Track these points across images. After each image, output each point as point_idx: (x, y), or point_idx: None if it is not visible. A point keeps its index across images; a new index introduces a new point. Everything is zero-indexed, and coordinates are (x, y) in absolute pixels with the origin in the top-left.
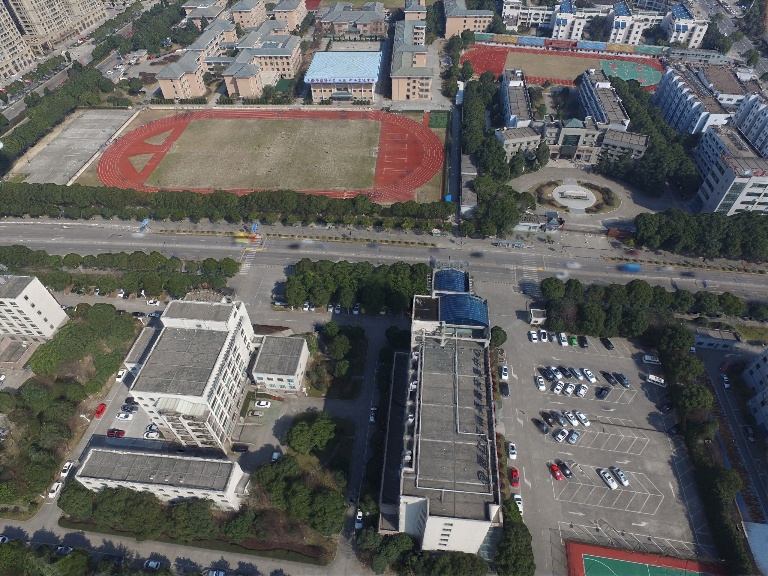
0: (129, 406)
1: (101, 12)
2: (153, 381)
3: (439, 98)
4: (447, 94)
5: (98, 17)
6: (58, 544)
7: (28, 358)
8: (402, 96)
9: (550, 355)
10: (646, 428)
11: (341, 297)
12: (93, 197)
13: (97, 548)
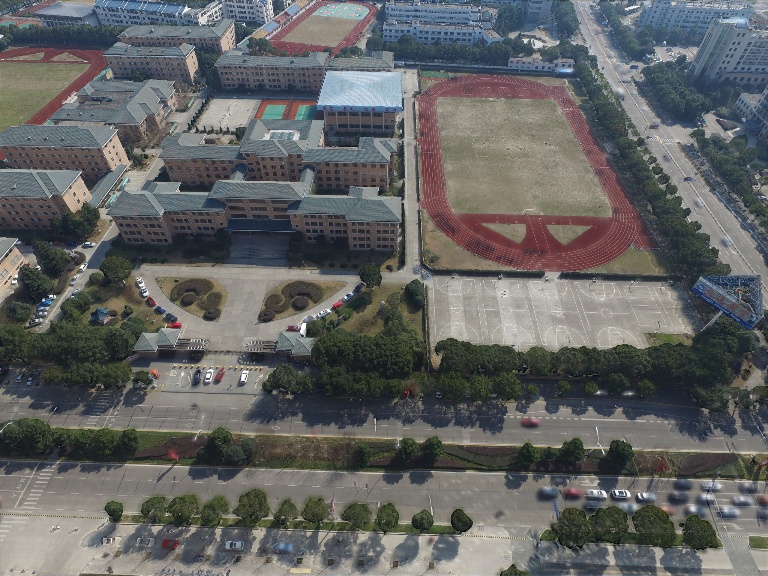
0: None
1: None
2: None
3: None
4: None
5: None
6: None
7: None
8: None
9: (667, 60)
10: (689, 49)
11: None
12: None
13: None
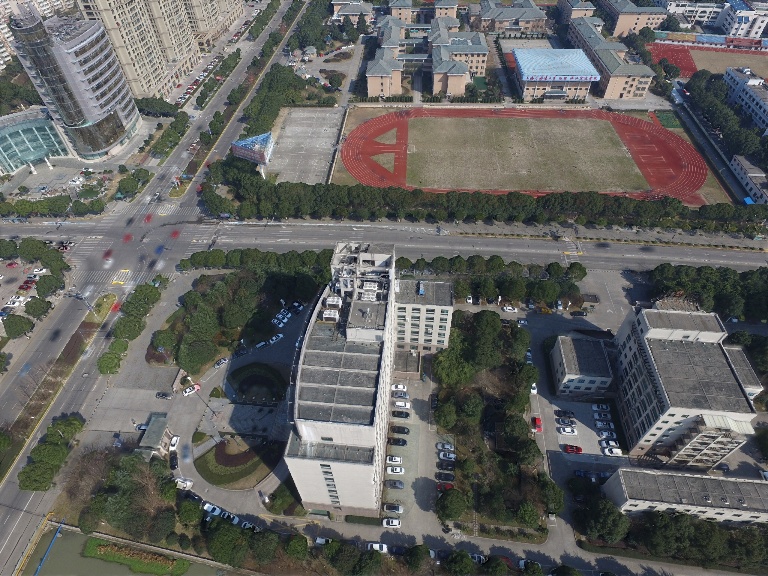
0: (568, 420)
1: (241, 8)
2: (686, 397)
3: (652, 97)
4: (658, 93)
5: (239, 13)
6: (596, 570)
7: (420, 368)
8: (615, 95)
9: None
10: None
11: (733, 305)
12: (381, 198)
13: (640, 575)
